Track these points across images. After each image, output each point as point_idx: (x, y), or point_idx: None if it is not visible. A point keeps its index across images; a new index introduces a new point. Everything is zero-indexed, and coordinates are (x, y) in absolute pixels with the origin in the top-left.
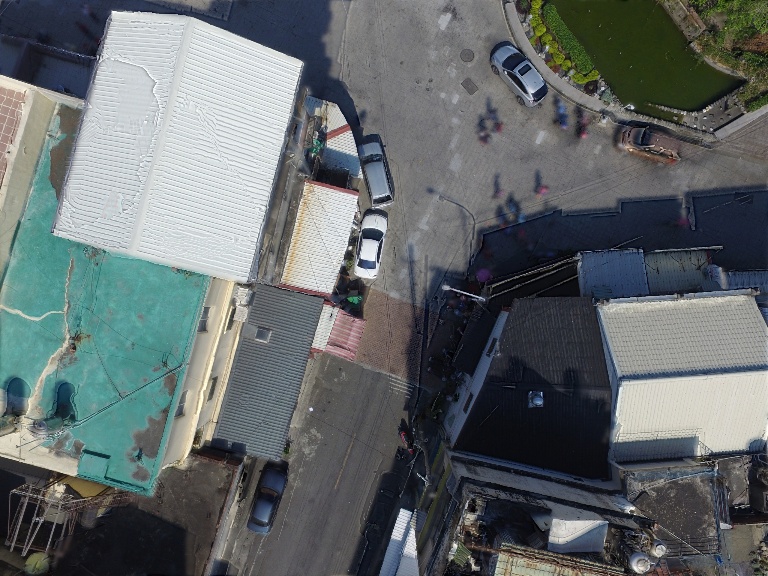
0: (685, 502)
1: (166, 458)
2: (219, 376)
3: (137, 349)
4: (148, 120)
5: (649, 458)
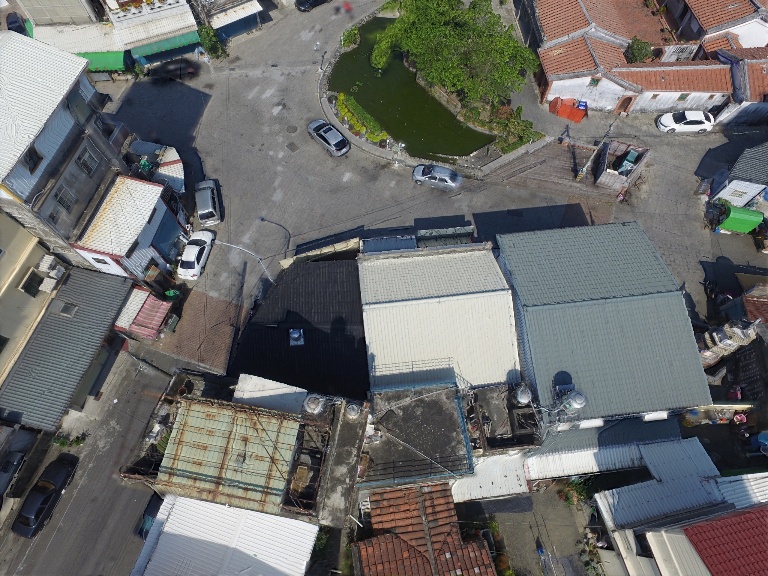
0: (432, 419)
1: None
2: (12, 341)
3: None
4: None
5: None
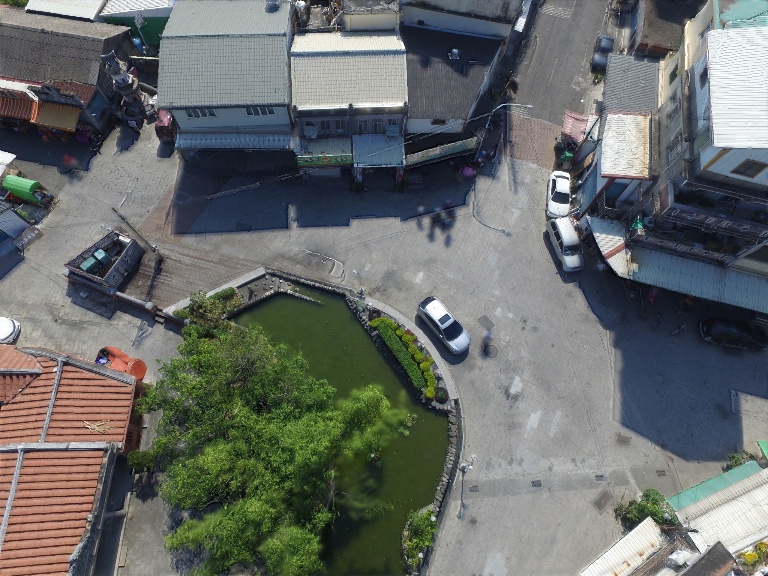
0: None
1: None
2: None
3: None
4: None
5: (372, 32)
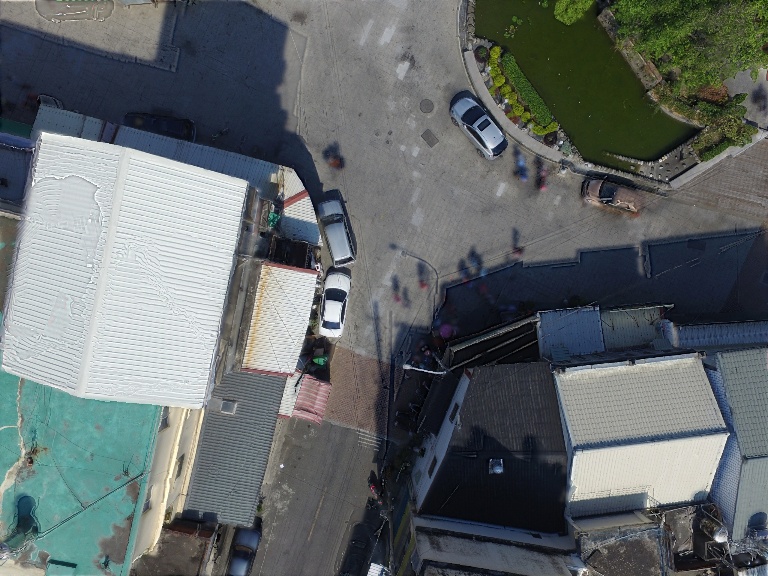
0: (634, 557)
1: (134, 555)
2: (186, 452)
3: (96, 460)
4: (92, 219)
5: (602, 512)
